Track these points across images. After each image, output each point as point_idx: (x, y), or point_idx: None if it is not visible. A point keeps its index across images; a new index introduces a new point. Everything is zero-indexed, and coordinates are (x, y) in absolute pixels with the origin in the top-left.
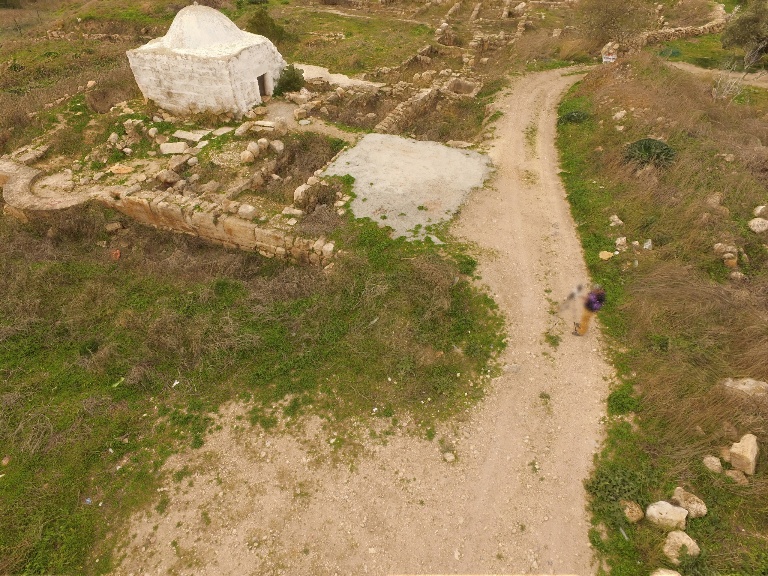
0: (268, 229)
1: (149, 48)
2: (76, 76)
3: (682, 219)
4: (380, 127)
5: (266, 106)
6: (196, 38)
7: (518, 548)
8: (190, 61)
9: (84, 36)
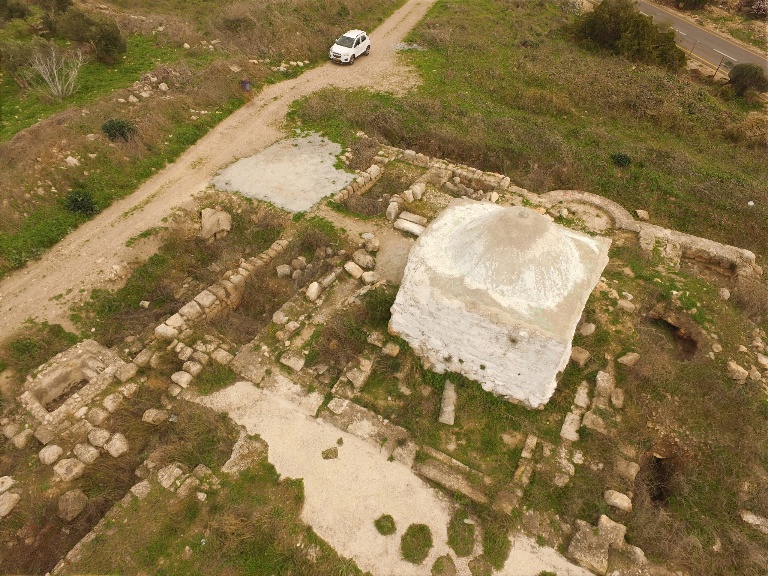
0: (396, 150)
1: (579, 235)
2: None
3: (169, 103)
4: (283, 241)
5: None
6: None
7: (322, 74)
8: None
9: None
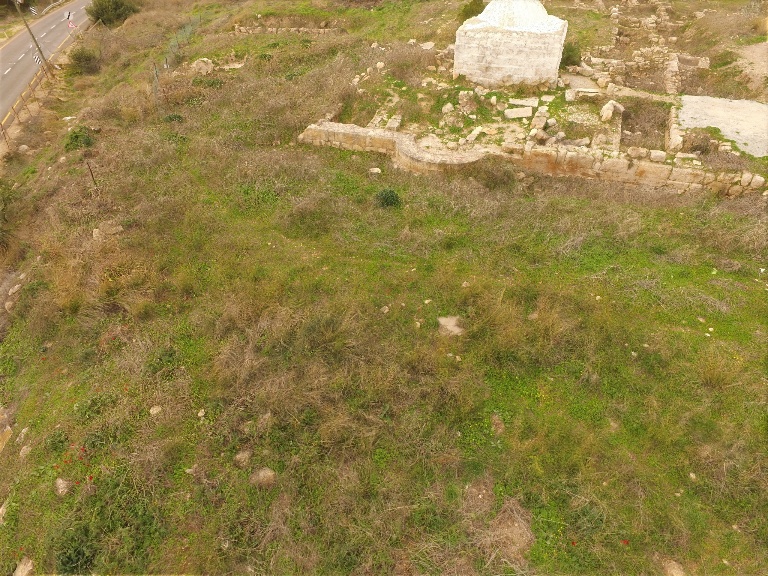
0: (684, 168)
1: (477, 28)
2: (323, 63)
3: None
4: (673, 92)
5: (561, 78)
6: (525, 17)
7: None
8: (526, 37)
9: (272, 30)
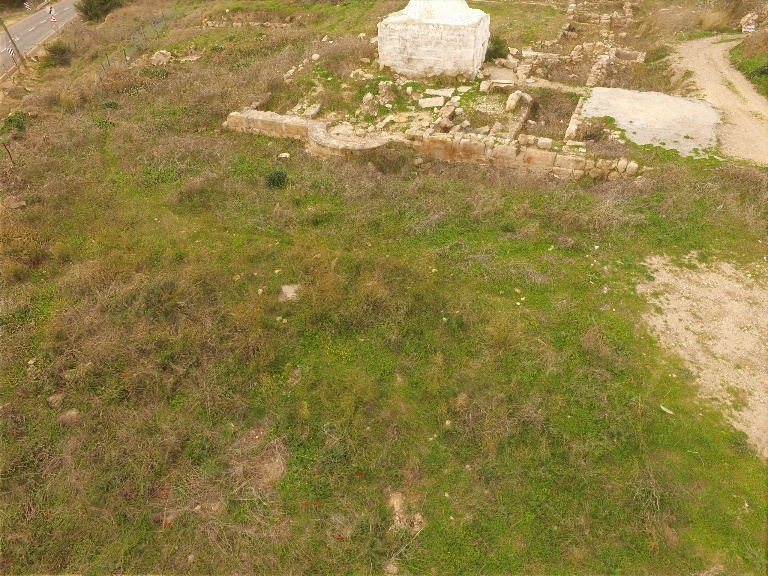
0: (568, 155)
1: (397, 20)
2: (271, 55)
3: None
4: (591, 84)
5: None
6: (442, 10)
7: None
8: (441, 29)
9: (237, 25)
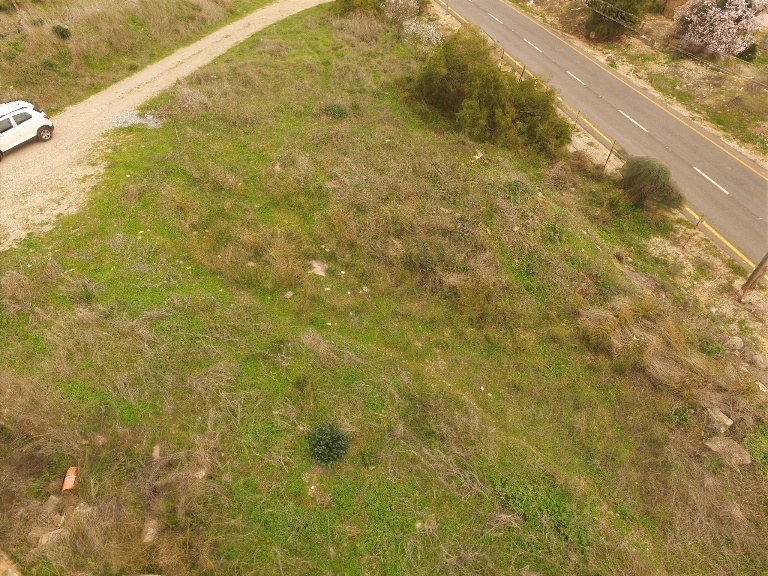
0: None
1: None
2: None
3: None
4: None
5: None
6: None
7: None
8: None
9: None
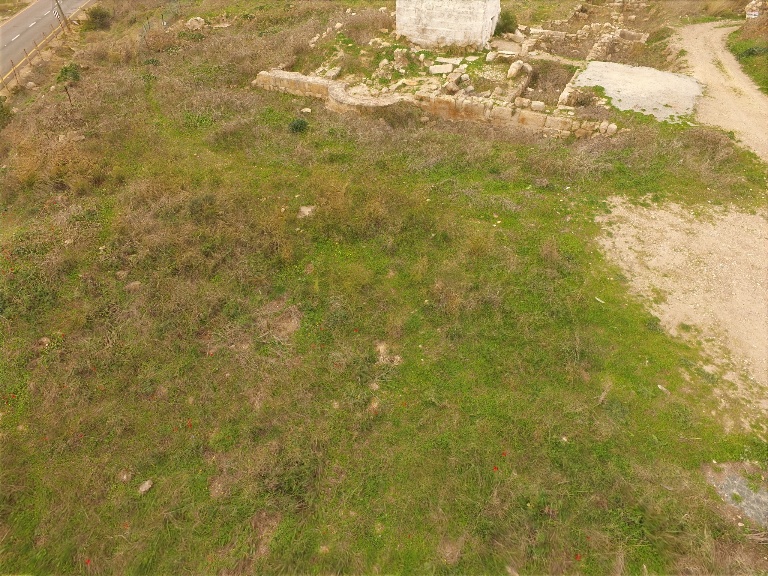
0: (557, 117)
1: None
2: (298, 24)
3: None
4: (590, 59)
5: None
6: None
7: None
8: (454, 2)
9: None
